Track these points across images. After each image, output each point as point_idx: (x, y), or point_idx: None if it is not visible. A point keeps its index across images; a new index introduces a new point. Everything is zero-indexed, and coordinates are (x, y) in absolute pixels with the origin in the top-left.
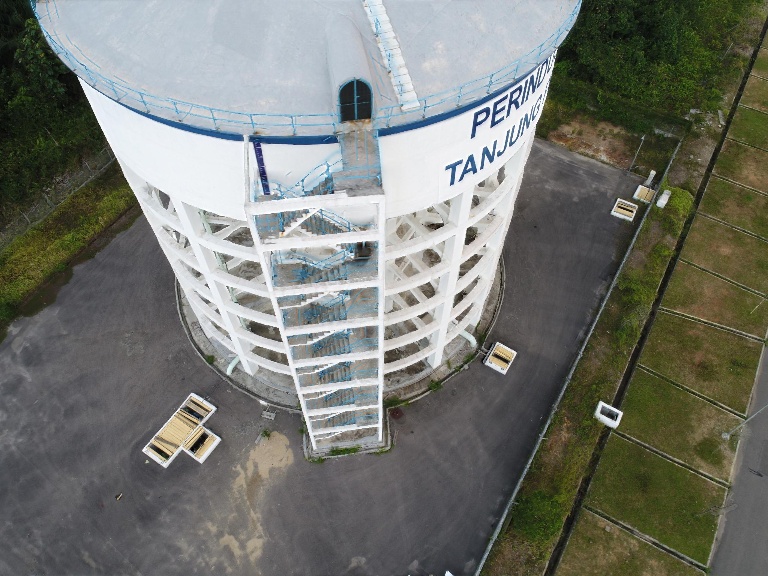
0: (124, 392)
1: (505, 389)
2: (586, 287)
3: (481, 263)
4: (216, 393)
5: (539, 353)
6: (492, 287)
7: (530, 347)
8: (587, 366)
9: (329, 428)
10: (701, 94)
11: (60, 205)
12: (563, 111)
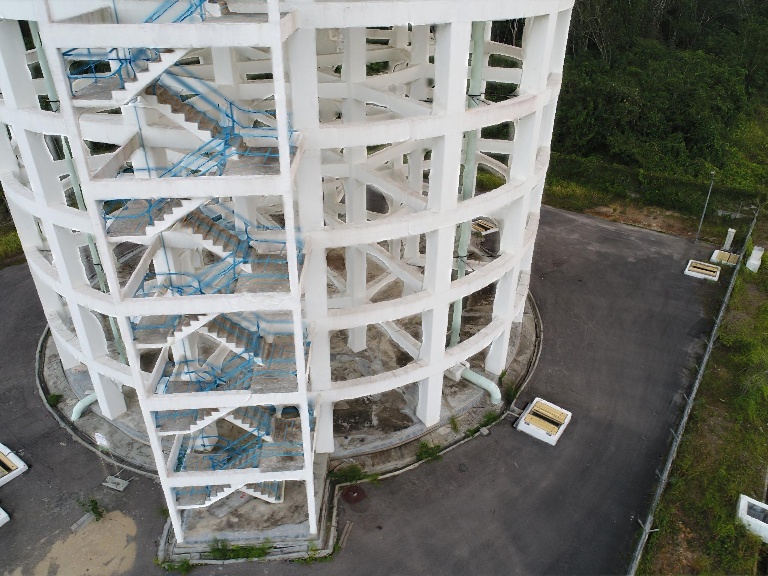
0: None
1: (557, 467)
2: (670, 343)
3: (502, 189)
4: (39, 445)
5: (610, 419)
6: (523, 335)
7: (593, 410)
8: (699, 444)
9: (203, 472)
10: (763, 189)
11: None
12: (598, 197)
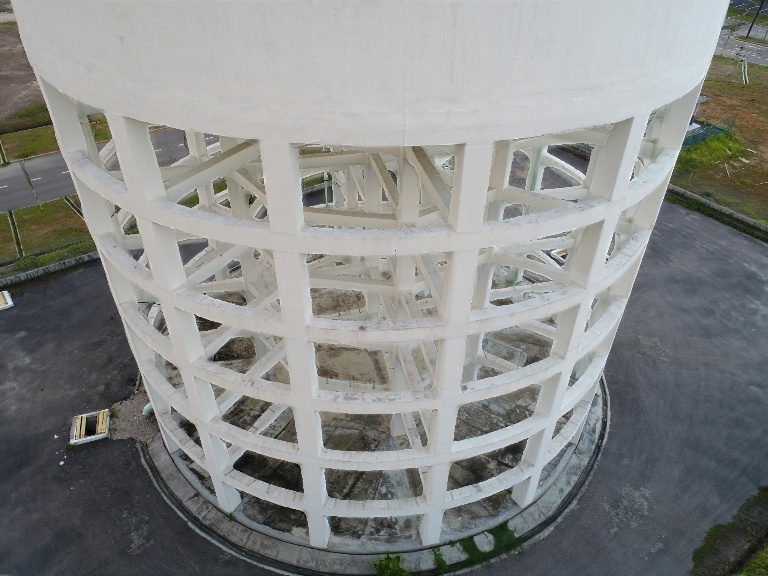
0: (653, 310)
1: None
2: None
3: None
4: None
5: None
6: None
7: None
8: None
9: None
10: None
11: None
12: None
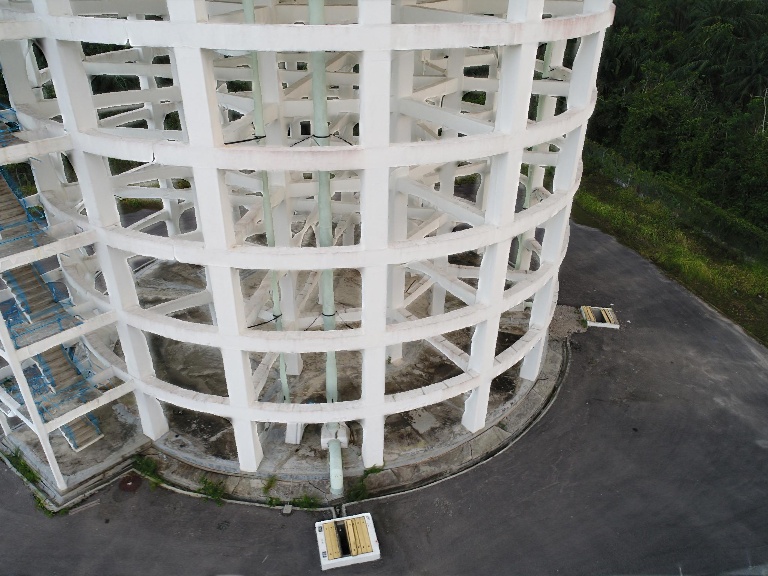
0: None
1: None
2: (644, 571)
3: (318, 249)
4: None
5: None
6: (462, 447)
7: (417, 570)
8: None
9: None
10: None
11: None
12: None
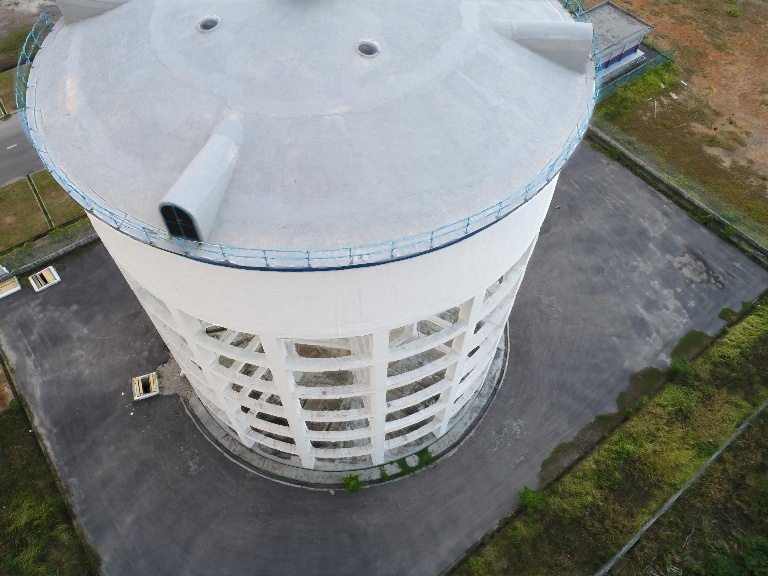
0: (557, 270)
1: None
2: None
3: None
4: None
5: None
6: None
7: None
8: None
9: None
10: None
11: (650, 518)
12: None
